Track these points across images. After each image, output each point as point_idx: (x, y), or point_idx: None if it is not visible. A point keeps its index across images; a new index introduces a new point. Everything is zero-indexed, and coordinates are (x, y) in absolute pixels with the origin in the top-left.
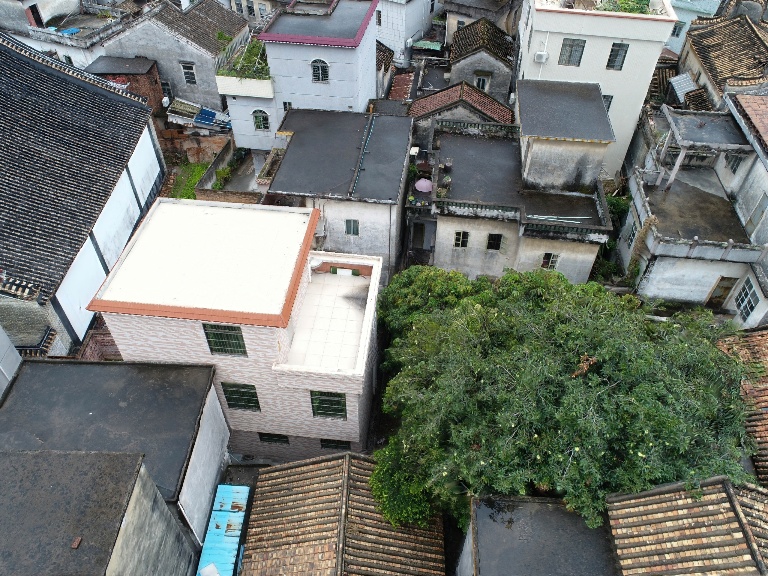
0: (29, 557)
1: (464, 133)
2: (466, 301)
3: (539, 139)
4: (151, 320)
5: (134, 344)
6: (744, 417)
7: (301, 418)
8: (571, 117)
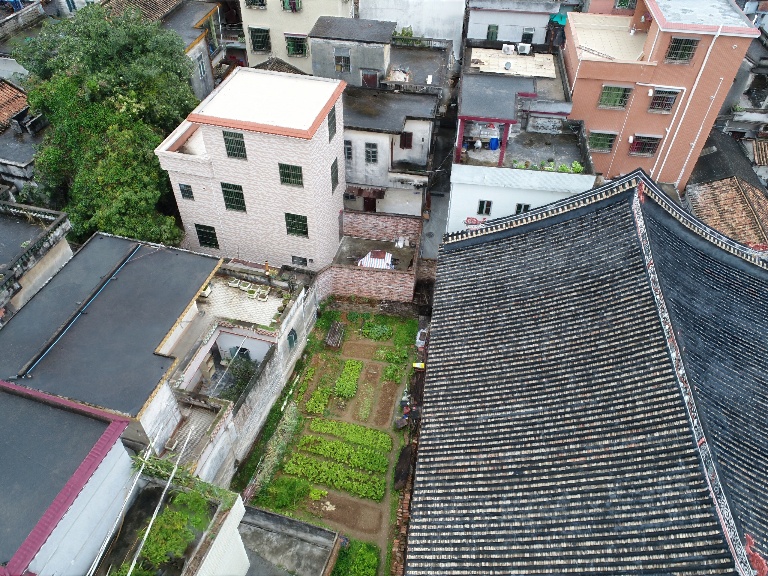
0: None
1: None
2: (133, 67)
3: None
4: None
5: None
6: (3, 125)
7: None
8: None
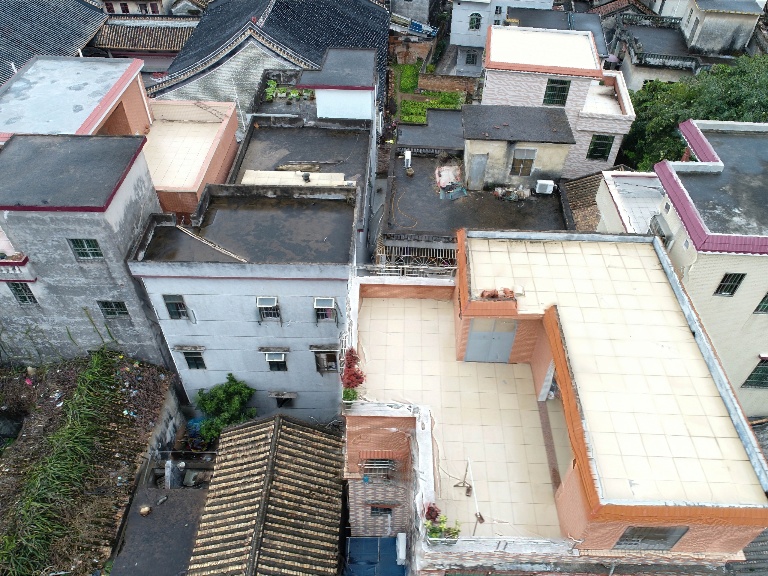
0: (535, 133)
1: (638, 24)
2: None
3: (710, 13)
4: (517, 77)
5: (496, 98)
6: None
7: (577, 161)
8: (730, 1)
